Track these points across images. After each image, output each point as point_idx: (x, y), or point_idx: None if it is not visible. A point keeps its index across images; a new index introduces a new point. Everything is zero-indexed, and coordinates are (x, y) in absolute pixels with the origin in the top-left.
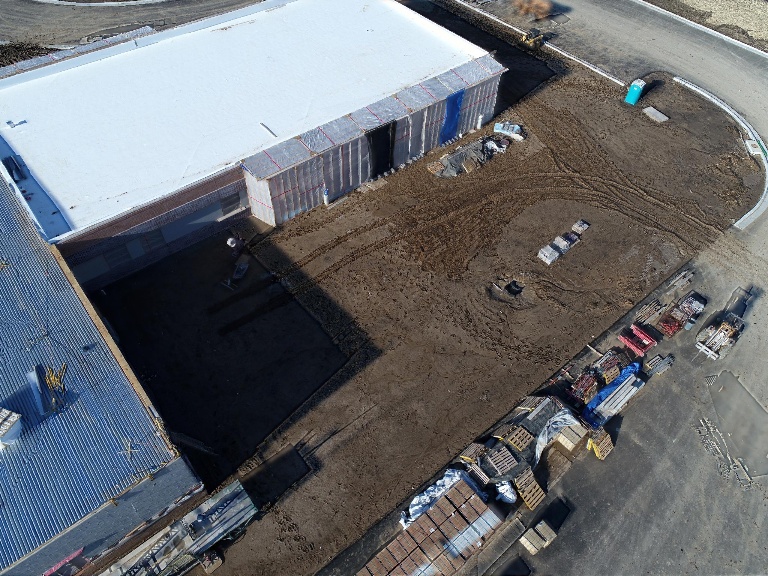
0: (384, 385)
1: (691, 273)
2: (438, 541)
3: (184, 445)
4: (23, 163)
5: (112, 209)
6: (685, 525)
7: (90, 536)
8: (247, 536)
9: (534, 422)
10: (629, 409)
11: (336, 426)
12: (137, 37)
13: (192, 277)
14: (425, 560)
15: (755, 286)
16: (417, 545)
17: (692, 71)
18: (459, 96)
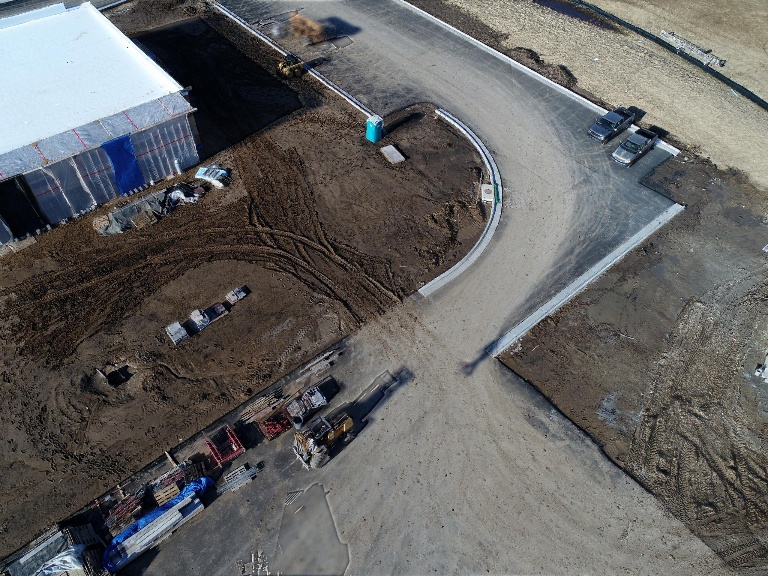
0: None
1: (338, 353)
2: None
3: None
4: None
5: None
6: None
7: None
8: None
9: (24, 567)
10: (172, 540)
11: None
12: None
13: None
14: None
15: (406, 369)
16: None
17: (460, 102)
18: (124, 142)
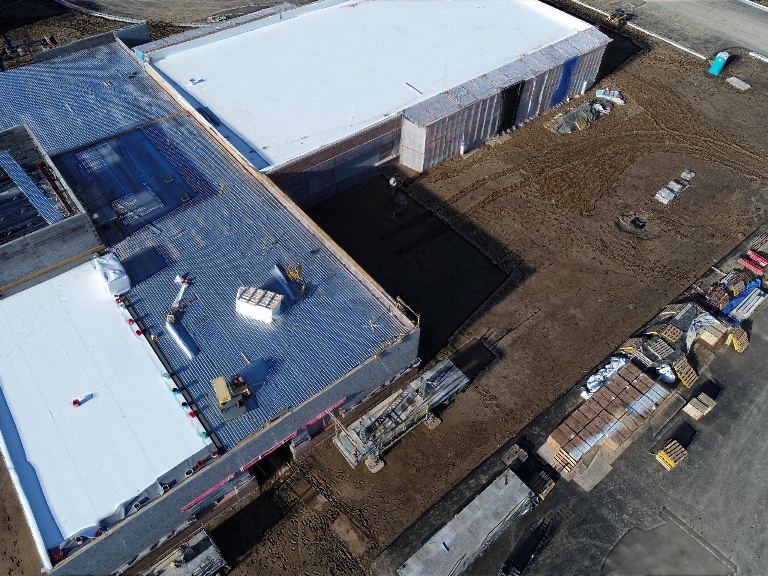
0: (543, 295)
1: None
2: (620, 405)
3: None
4: (212, 113)
5: (299, 149)
6: None
7: (352, 387)
8: (456, 404)
9: (681, 321)
10: (757, 315)
11: (510, 325)
12: (282, 11)
13: (360, 211)
14: (612, 419)
15: None
16: (603, 408)
17: (765, 47)
18: (573, 62)
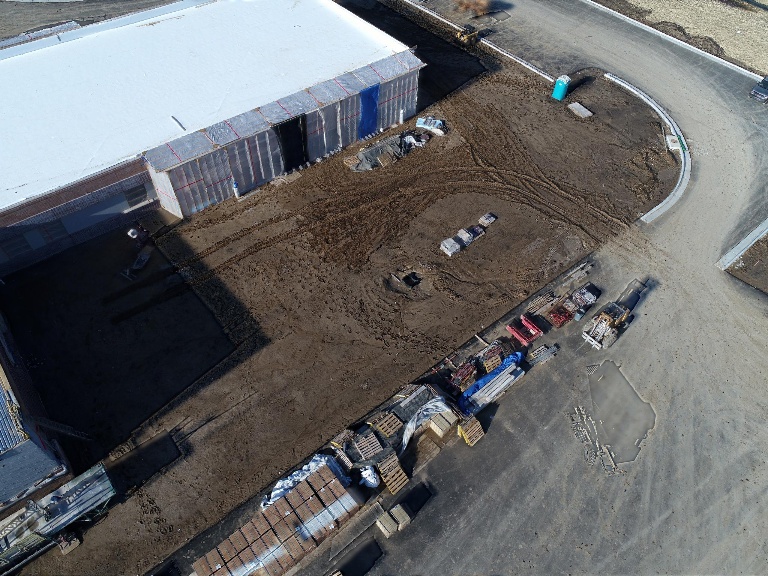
0: (267, 373)
1: (590, 265)
2: (291, 523)
3: (46, 429)
4: None
5: (9, 200)
6: (543, 509)
7: None
8: (108, 518)
9: (406, 409)
10: (506, 397)
11: (213, 413)
12: (60, 32)
13: (93, 267)
14: (276, 541)
15: (652, 278)
16: (270, 527)
17: (624, 67)
18: (374, 91)
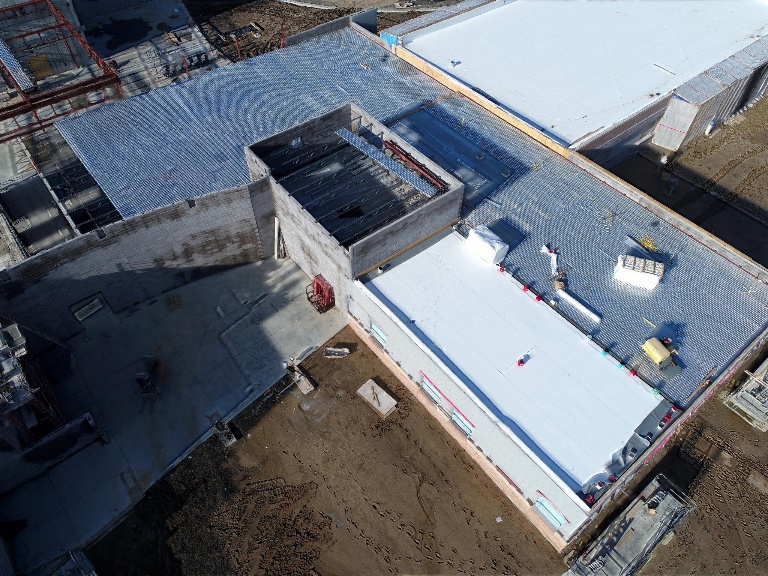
0: None
1: None
2: None
3: None
4: (485, 93)
5: (587, 127)
6: None
7: None
8: None
9: None
10: None
11: None
12: None
13: None
14: None
15: None
16: None
17: None
18: None
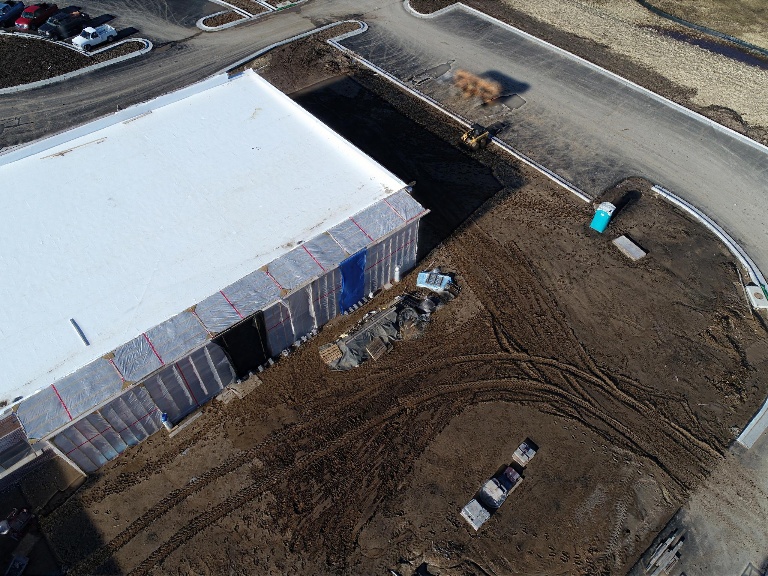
0: None
1: (680, 539)
2: None
3: None
4: None
5: None
6: None
7: None
8: None
9: None
10: None
11: None
12: None
13: None
14: None
15: None
16: None
17: (675, 176)
18: (359, 257)
